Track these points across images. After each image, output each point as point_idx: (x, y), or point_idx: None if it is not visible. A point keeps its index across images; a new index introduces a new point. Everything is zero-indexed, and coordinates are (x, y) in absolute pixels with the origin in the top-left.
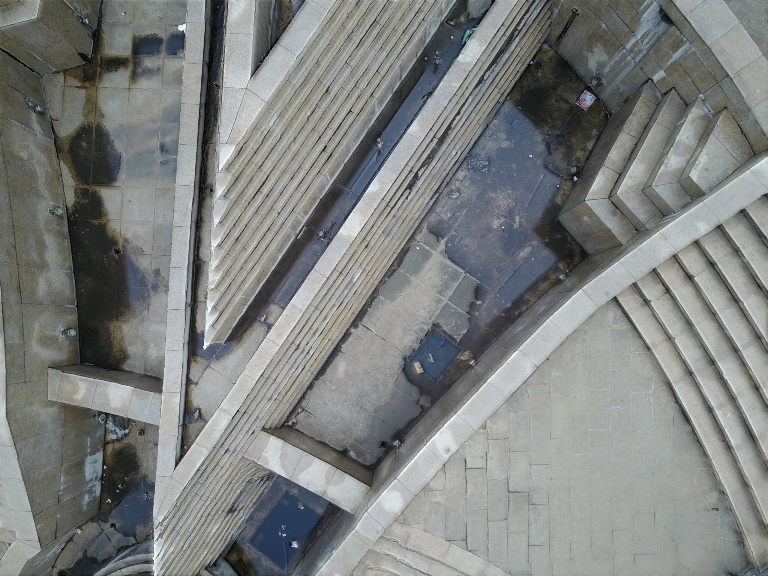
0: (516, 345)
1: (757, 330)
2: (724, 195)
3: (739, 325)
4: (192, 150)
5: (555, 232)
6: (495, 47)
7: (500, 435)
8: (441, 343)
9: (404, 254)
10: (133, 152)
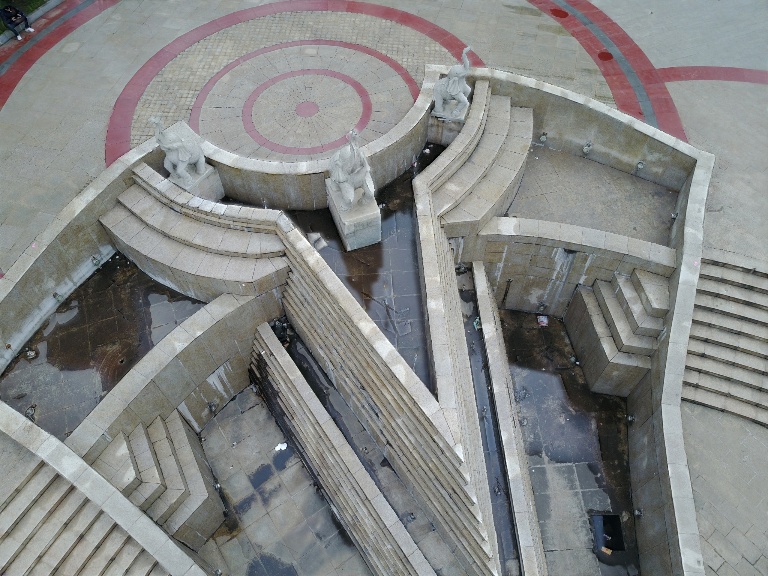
0: (661, 465)
1: (760, 355)
2: (680, 303)
3: (749, 360)
4: (382, 497)
5: (597, 400)
6: None
7: (709, 531)
8: (601, 523)
9: None
10: (300, 556)
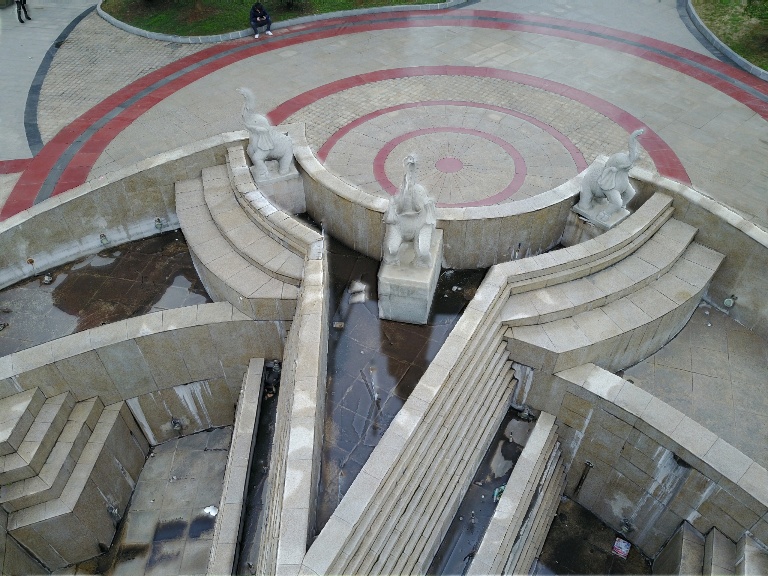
0: None
1: None
2: None
3: None
4: None
5: None
6: (525, 502)
7: None
8: None
9: None
10: None
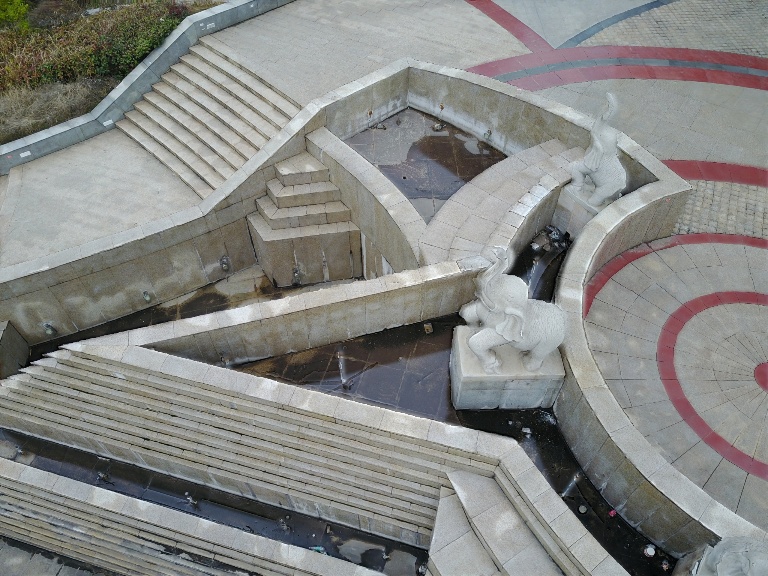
0: None
1: None
2: None
3: None
4: None
5: None
6: None
7: None
8: None
9: None
10: None
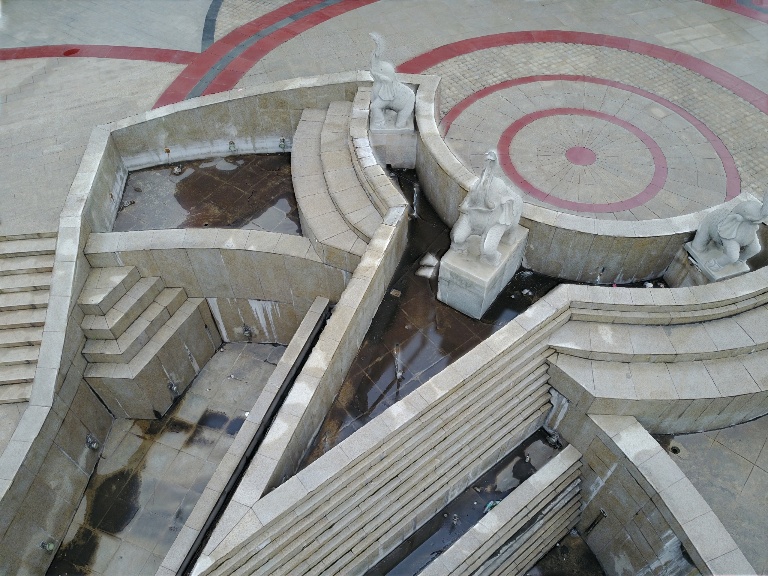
0: None
1: None
2: None
3: None
4: (193, 535)
5: None
6: (516, 525)
7: None
8: None
9: None
10: (151, 509)
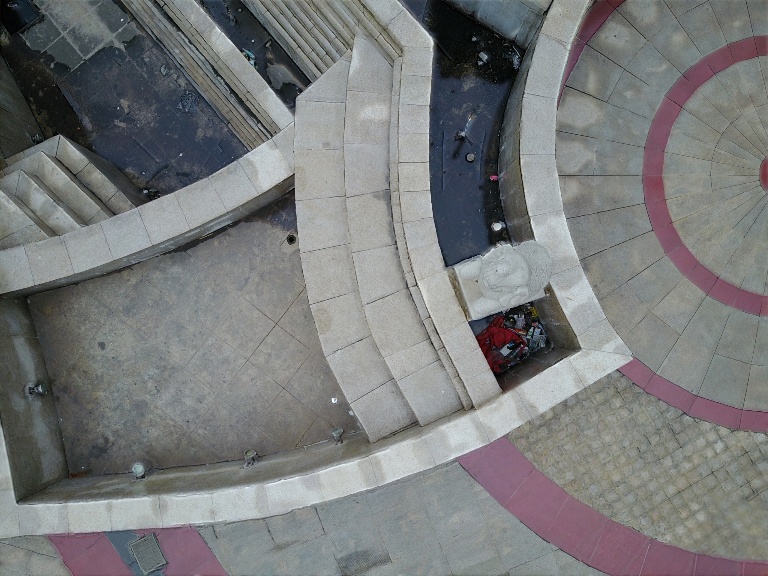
0: None
1: None
2: None
3: None
4: None
5: None
6: None
7: None
8: None
9: (121, 6)
10: None
